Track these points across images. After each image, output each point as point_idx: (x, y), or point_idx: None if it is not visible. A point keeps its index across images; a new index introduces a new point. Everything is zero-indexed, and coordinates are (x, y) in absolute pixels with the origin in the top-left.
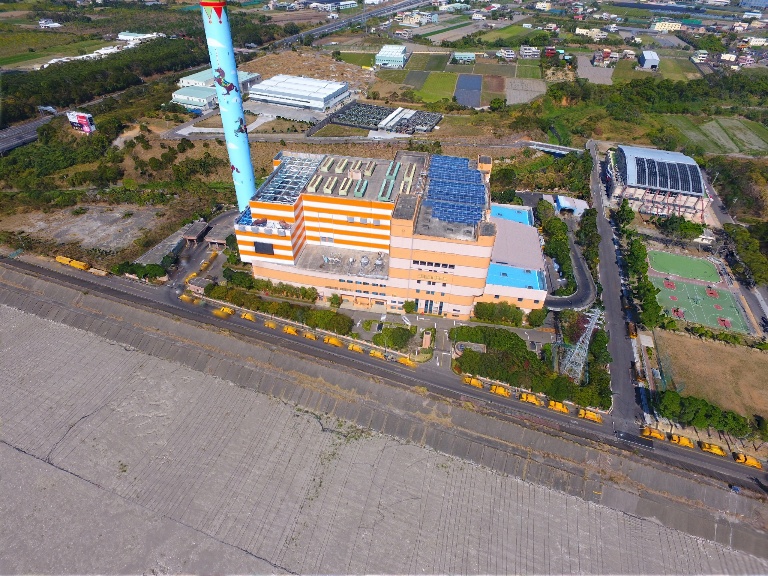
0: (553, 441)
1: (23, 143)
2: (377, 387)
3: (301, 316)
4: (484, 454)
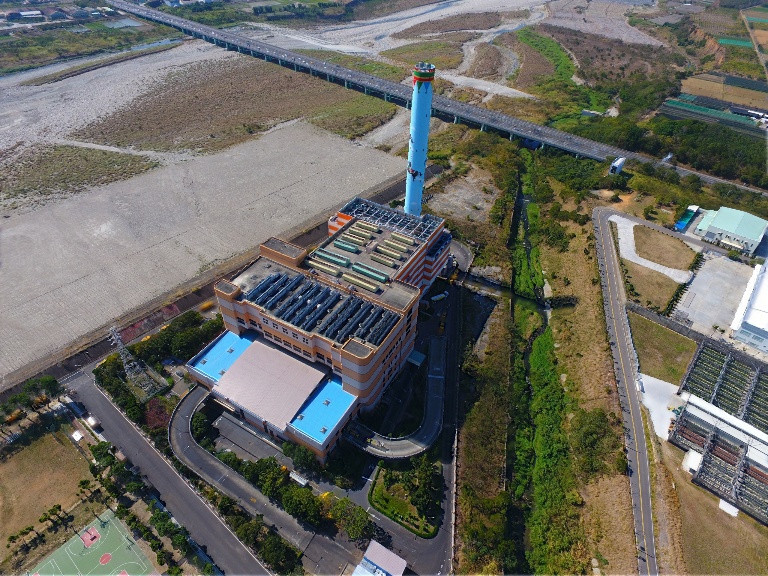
0: None
1: (602, 160)
2: None
3: None
4: None
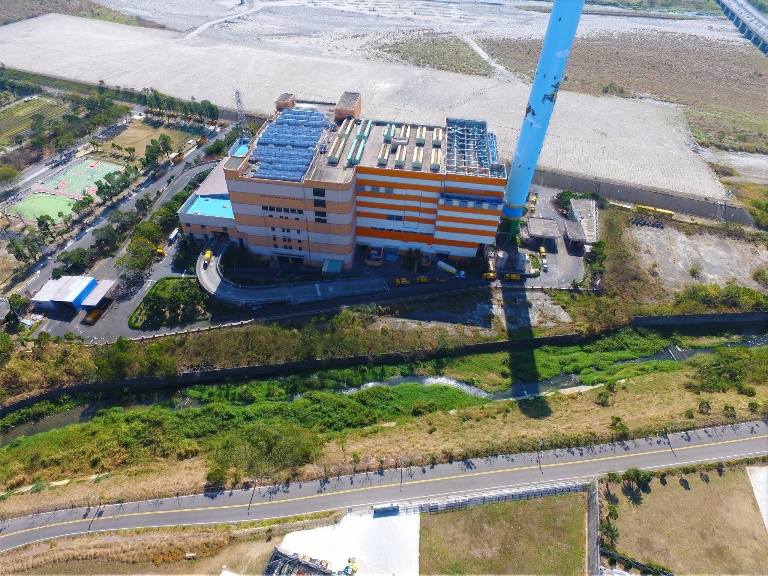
0: None
1: None
2: None
3: None
4: None
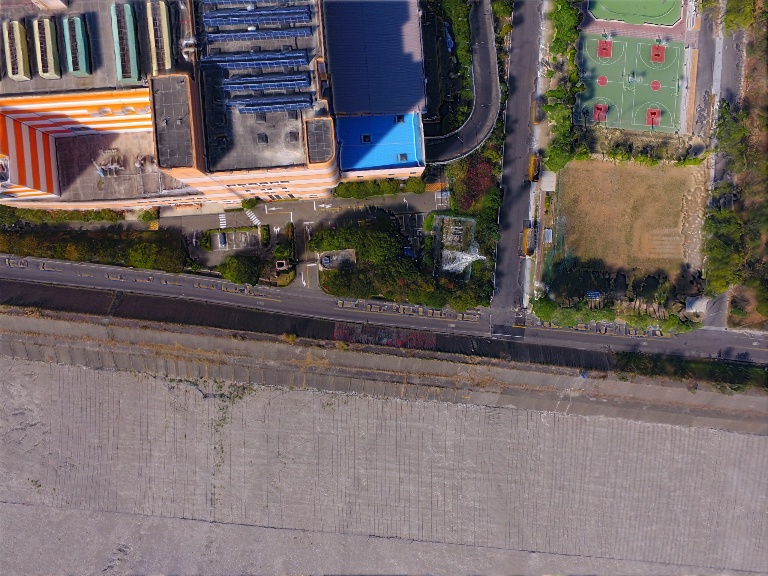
0: (428, 363)
1: None
2: (243, 344)
3: (115, 260)
4: (364, 386)
